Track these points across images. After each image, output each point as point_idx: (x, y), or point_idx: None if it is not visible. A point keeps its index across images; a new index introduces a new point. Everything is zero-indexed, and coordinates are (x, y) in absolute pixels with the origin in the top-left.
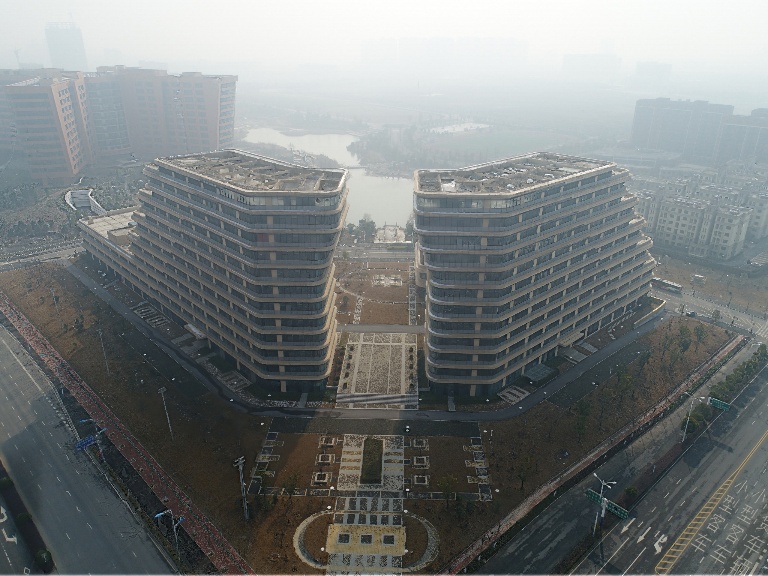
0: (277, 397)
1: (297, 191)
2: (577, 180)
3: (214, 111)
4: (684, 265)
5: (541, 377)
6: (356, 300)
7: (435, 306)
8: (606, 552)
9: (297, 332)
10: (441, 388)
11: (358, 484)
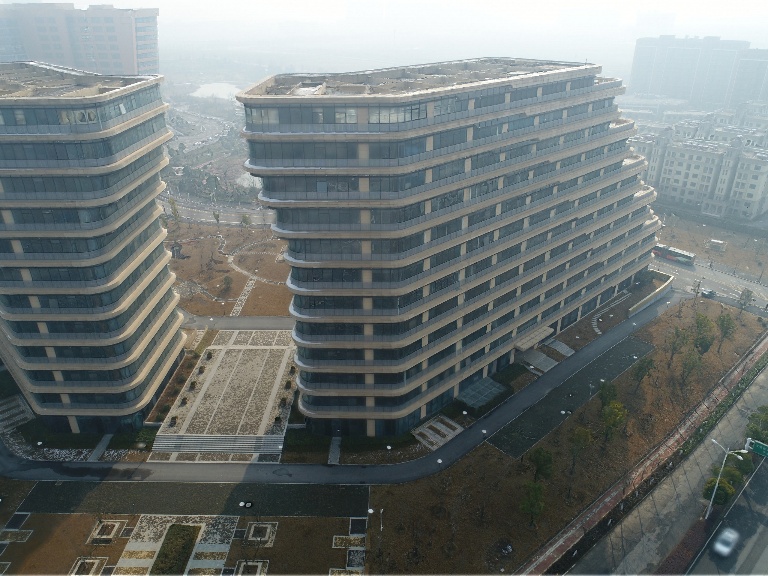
0: (61, 443)
1: (21, 97)
2: (534, 84)
3: (129, 52)
4: (696, 227)
5: (484, 401)
6: (246, 281)
7: (297, 297)
8: None
9: (74, 342)
10: (321, 424)
11: None
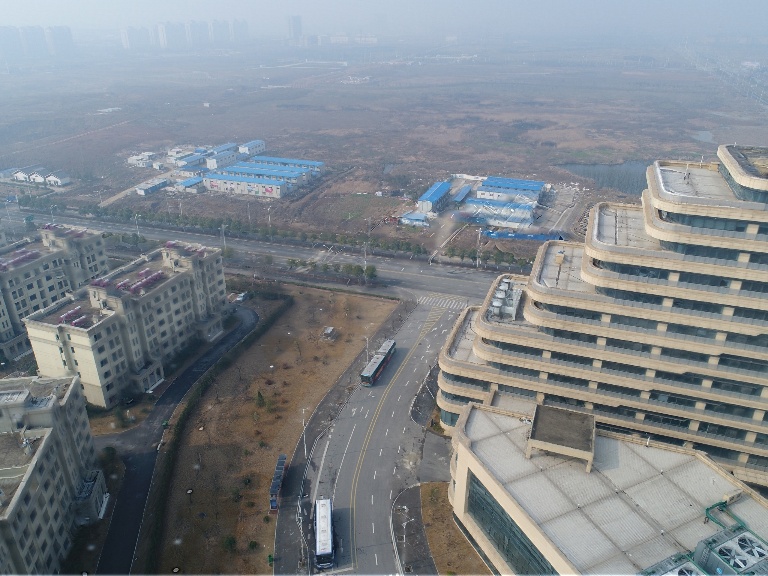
0: None
1: None
2: None
3: None
4: (270, 346)
5: None
6: None
7: None
8: None
9: None
10: None
11: None
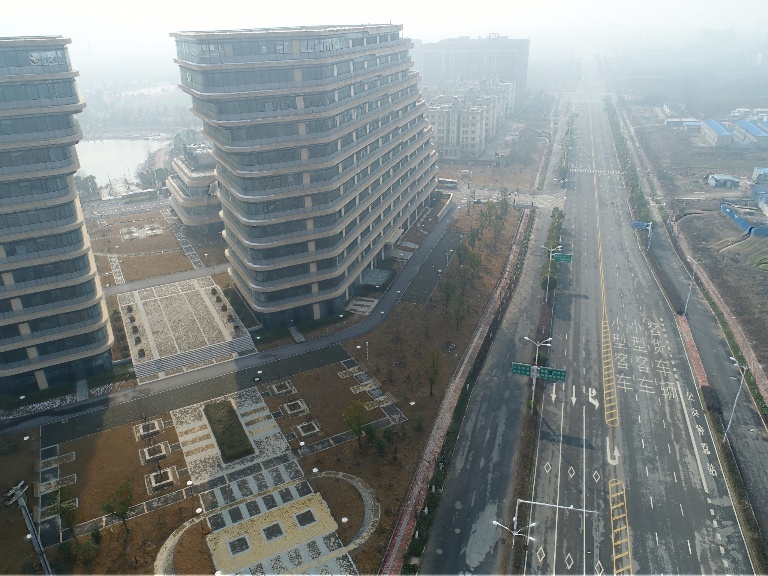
0: (35, 398)
1: None
2: (376, 33)
3: None
4: (446, 166)
5: (382, 280)
6: (108, 259)
7: (250, 207)
8: (553, 426)
9: (46, 286)
10: (277, 319)
11: (222, 466)
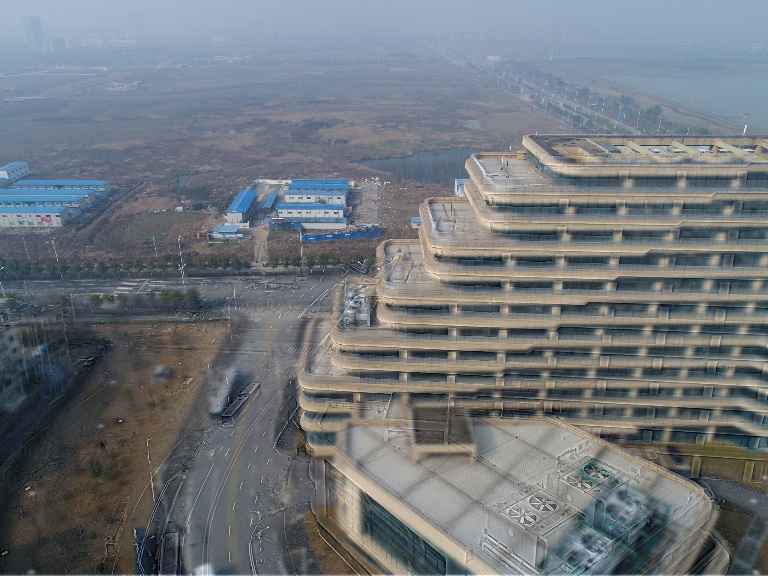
0: None
1: None
2: None
3: None
4: (120, 402)
5: None
6: None
7: None
8: None
9: None
10: None
11: None
